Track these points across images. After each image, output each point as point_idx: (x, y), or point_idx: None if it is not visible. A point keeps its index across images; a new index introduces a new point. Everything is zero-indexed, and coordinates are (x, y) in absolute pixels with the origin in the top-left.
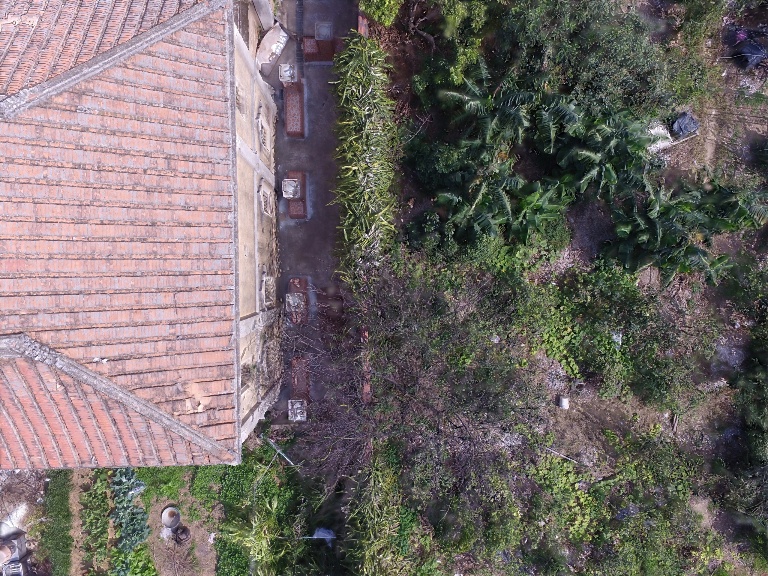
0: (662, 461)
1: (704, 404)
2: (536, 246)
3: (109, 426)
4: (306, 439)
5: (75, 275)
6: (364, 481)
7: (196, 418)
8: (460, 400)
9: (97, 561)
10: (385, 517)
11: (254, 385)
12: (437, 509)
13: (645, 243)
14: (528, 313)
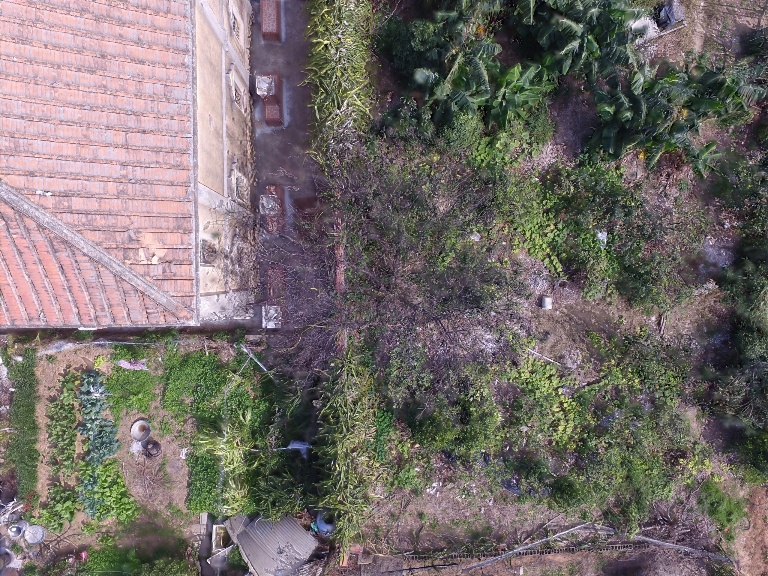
0: (648, 356)
1: (692, 307)
2: (518, 138)
3: (56, 274)
4: None
5: (16, 99)
6: (337, 374)
7: (150, 269)
8: (439, 299)
9: (64, 476)
10: (359, 412)
11: (221, 271)
12: (414, 408)
13: (629, 121)
14: (508, 200)
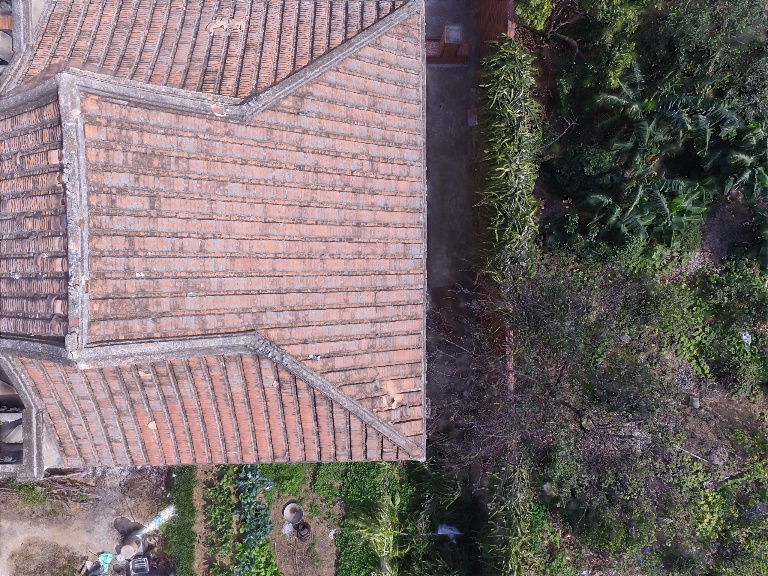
0: None
1: None
2: None
3: (310, 422)
4: None
5: (295, 274)
6: (508, 478)
7: (391, 415)
8: (592, 399)
9: (220, 556)
10: (528, 514)
11: None
12: (575, 506)
13: None
14: (670, 313)
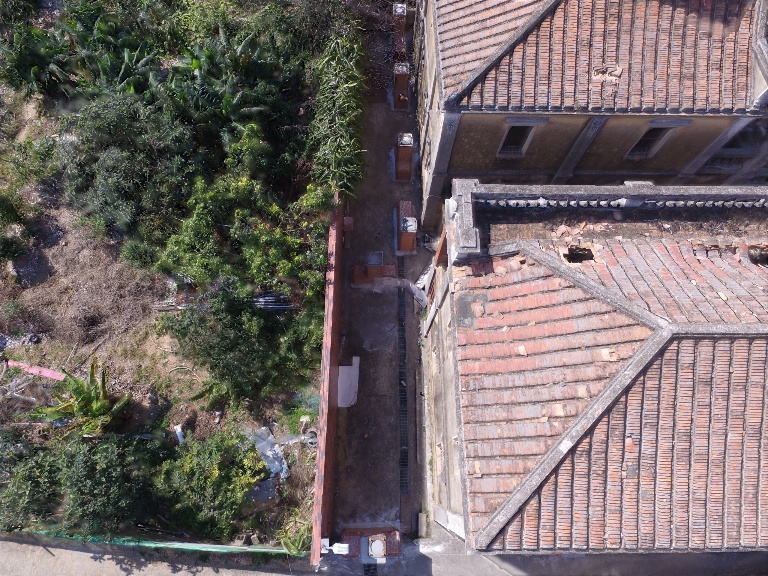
0: None
1: None
2: None
3: None
4: (394, 3)
5: None
6: None
7: None
8: None
9: None
10: None
11: None
12: None
13: None
14: (215, 8)
